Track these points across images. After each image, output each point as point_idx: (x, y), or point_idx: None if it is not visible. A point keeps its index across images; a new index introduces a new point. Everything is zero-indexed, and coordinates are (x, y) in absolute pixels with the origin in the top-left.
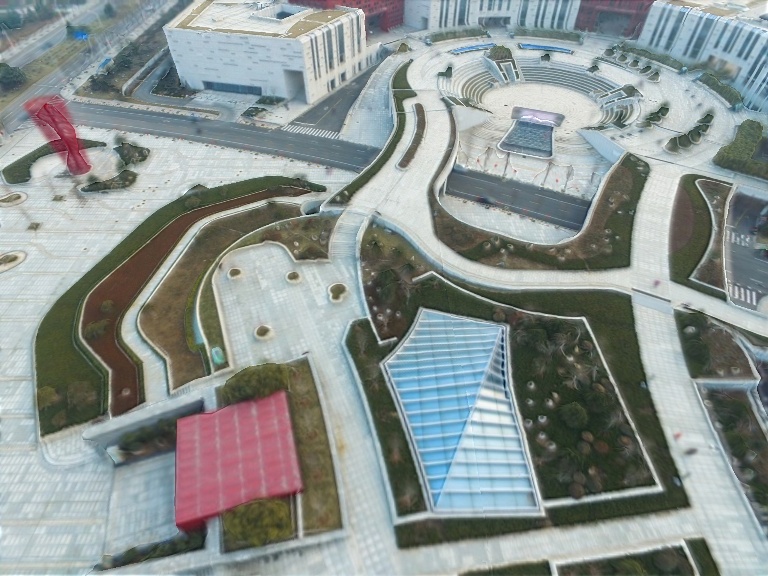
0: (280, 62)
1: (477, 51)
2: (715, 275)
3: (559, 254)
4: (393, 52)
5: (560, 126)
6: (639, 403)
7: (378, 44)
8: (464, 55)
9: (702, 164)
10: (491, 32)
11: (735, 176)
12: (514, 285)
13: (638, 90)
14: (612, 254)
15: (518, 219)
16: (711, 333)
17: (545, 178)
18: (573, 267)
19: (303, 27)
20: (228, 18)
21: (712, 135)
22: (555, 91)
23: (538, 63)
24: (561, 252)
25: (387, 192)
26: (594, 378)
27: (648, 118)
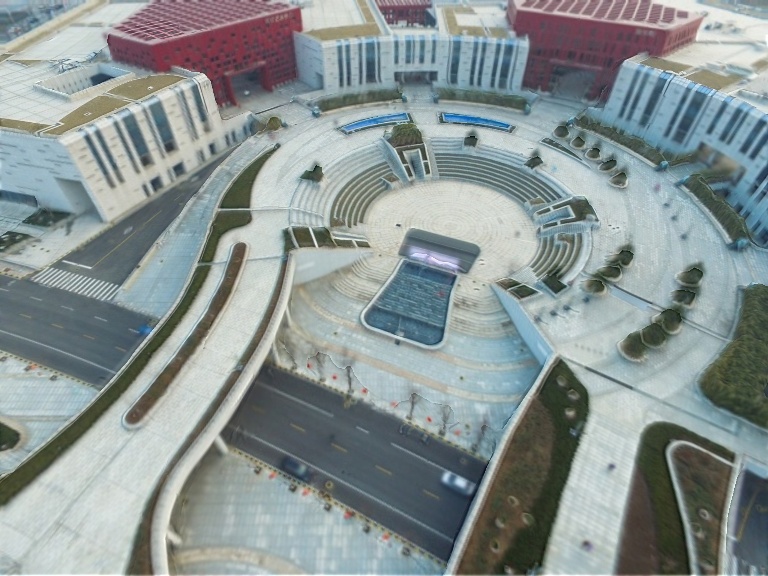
0: (45, 168)
1: (379, 127)
2: None
3: None
4: (265, 126)
5: (468, 272)
6: None
7: (245, 115)
8: (358, 135)
9: (681, 390)
10: (411, 92)
11: (738, 428)
12: None
13: (593, 206)
14: None
15: (339, 523)
16: None
17: (411, 411)
18: None
19: (94, 109)
20: (2, 89)
21: (700, 310)
22: (478, 195)
23: (460, 148)
24: None
25: (70, 500)
26: None
27: (601, 269)
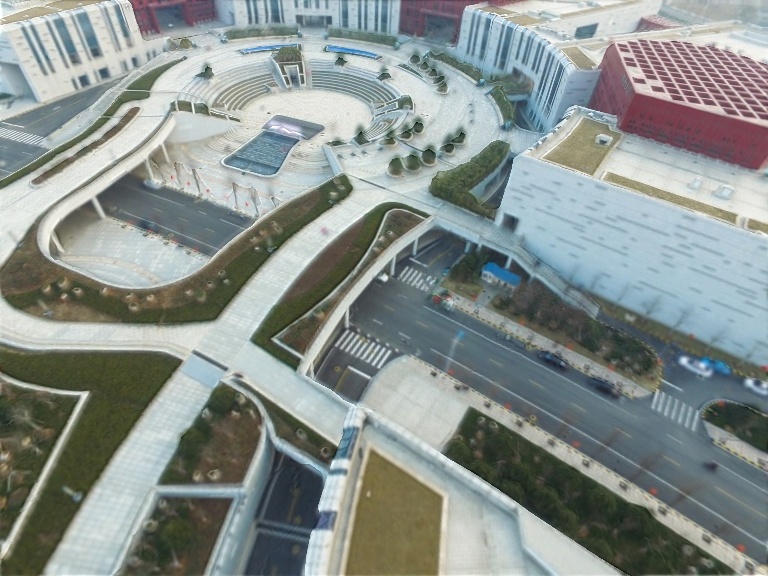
0: None
1: (272, 51)
2: (303, 335)
3: (132, 302)
4: None
5: (309, 139)
6: (47, 525)
7: (164, 38)
8: (253, 55)
9: (417, 190)
10: (309, 32)
11: (442, 206)
12: (41, 344)
13: (413, 102)
14: (204, 303)
15: (171, 250)
16: (227, 418)
17: (235, 201)
18: (142, 319)
19: (31, 14)
20: None
21: (457, 156)
22: (338, 99)
23: (332, 67)
24: (143, 299)
25: None
26: (8, 487)
27: (399, 134)
